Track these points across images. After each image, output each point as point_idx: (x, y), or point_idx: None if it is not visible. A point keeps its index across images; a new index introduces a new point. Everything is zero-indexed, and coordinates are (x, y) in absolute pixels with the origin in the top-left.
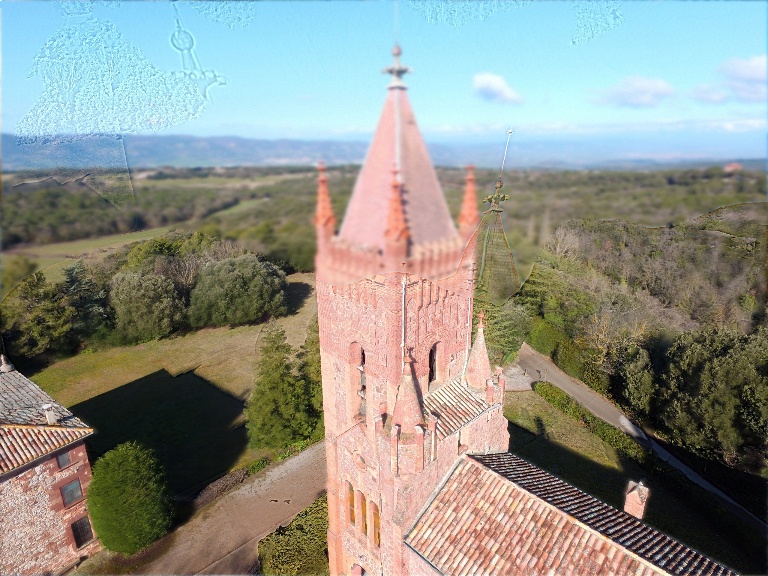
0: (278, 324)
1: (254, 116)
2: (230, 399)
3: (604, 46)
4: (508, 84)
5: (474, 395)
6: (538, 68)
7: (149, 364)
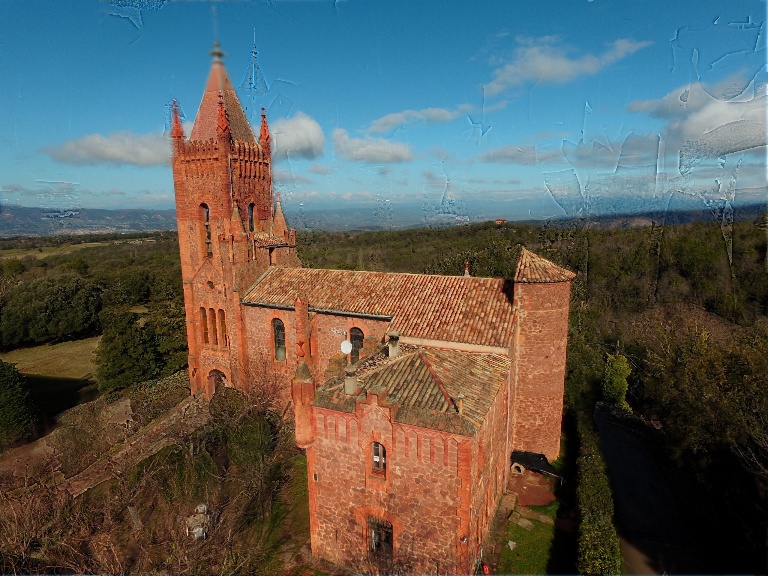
0: None
1: (177, 13)
2: (67, 379)
3: (275, 7)
4: (251, 13)
5: (278, 239)
6: (259, 10)
7: None
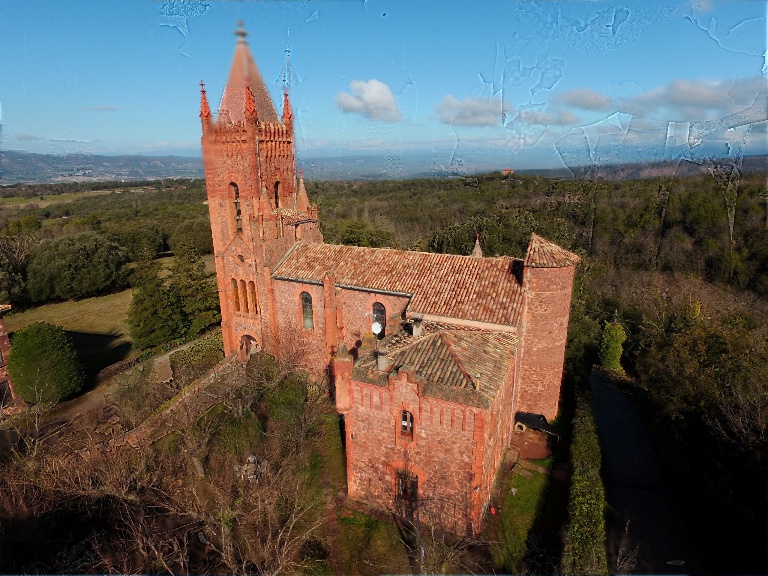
0: (127, 293)
1: (217, 17)
2: (99, 336)
3: (307, 8)
4: (286, 15)
5: (301, 214)
6: (293, 11)
7: None
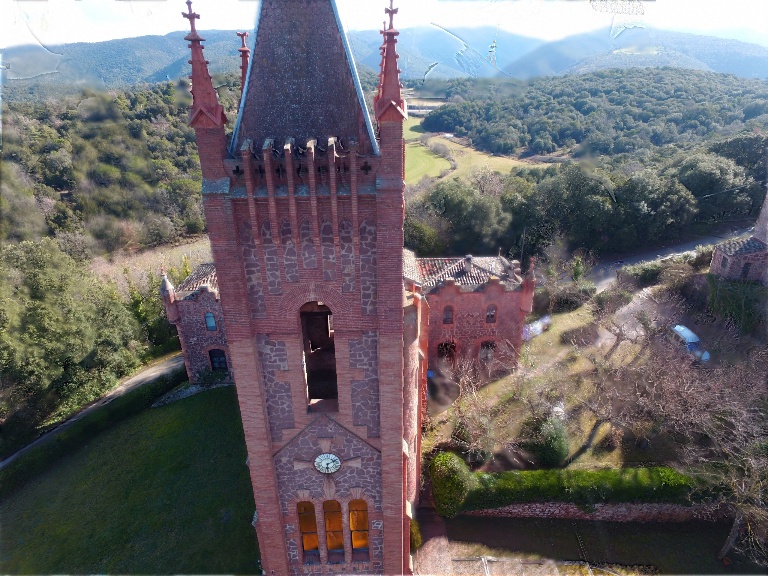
0: None
1: (574, 10)
2: None
3: (487, 4)
4: (506, 10)
5: None
6: (500, 7)
7: None
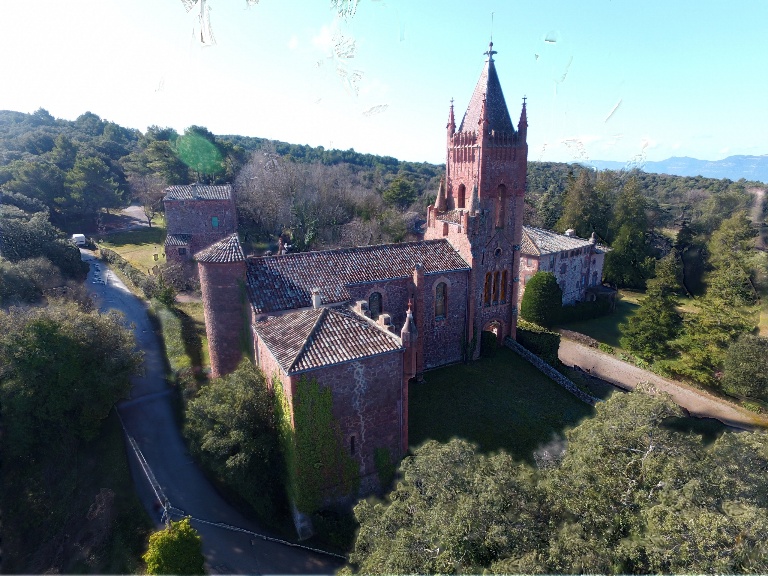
0: None
1: None
2: None
3: None
4: None
5: None
6: None
7: (759, 326)
